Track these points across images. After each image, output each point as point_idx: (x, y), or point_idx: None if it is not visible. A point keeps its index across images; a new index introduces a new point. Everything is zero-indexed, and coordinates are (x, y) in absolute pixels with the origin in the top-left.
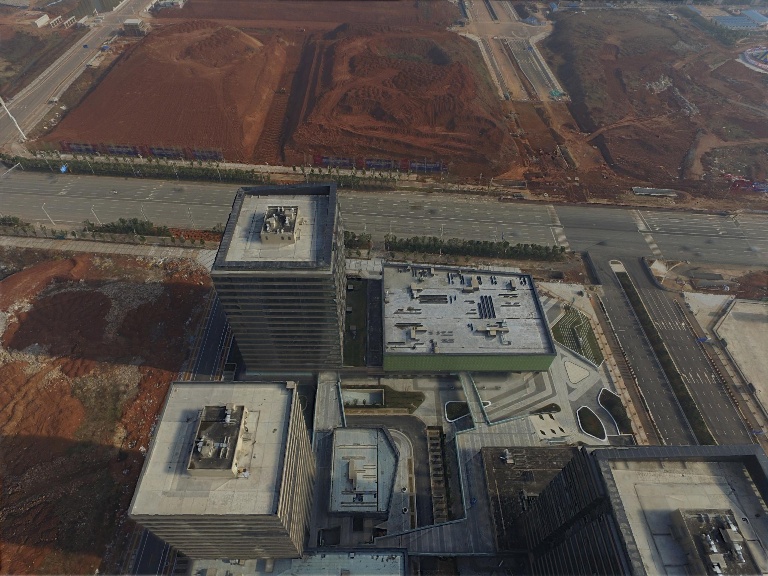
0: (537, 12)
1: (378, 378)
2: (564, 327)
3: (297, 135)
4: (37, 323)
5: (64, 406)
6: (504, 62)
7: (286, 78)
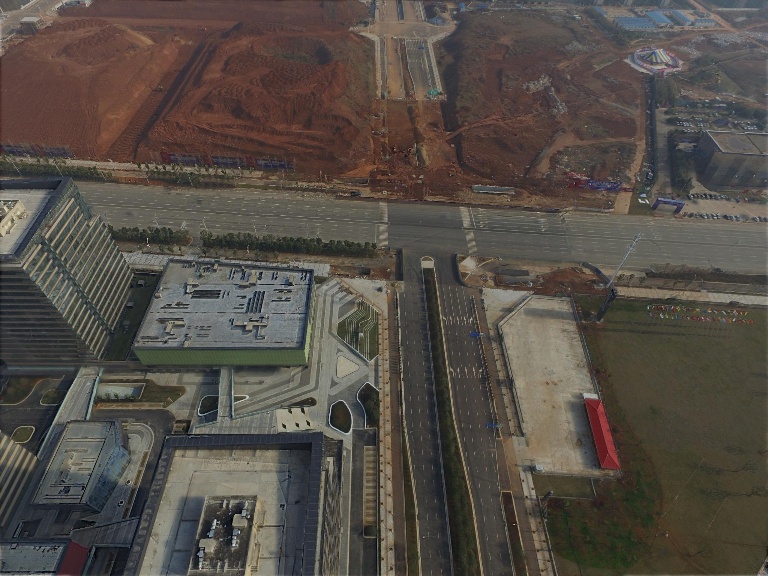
0: (445, 12)
1: (145, 373)
2: (350, 322)
3: (152, 133)
4: None
5: None
6: (393, 61)
7: (169, 76)
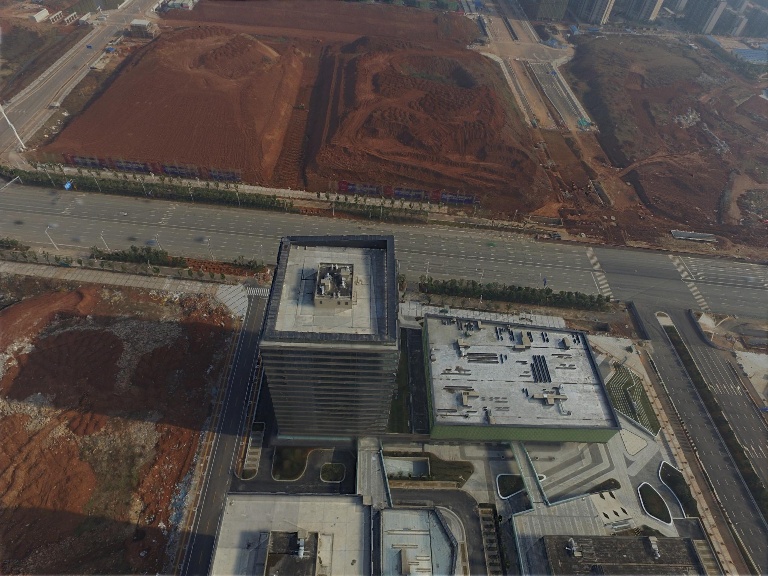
0: (557, 34)
1: (422, 444)
2: (616, 388)
3: (320, 158)
4: (40, 368)
5: (72, 472)
6: (528, 86)
7: (304, 92)
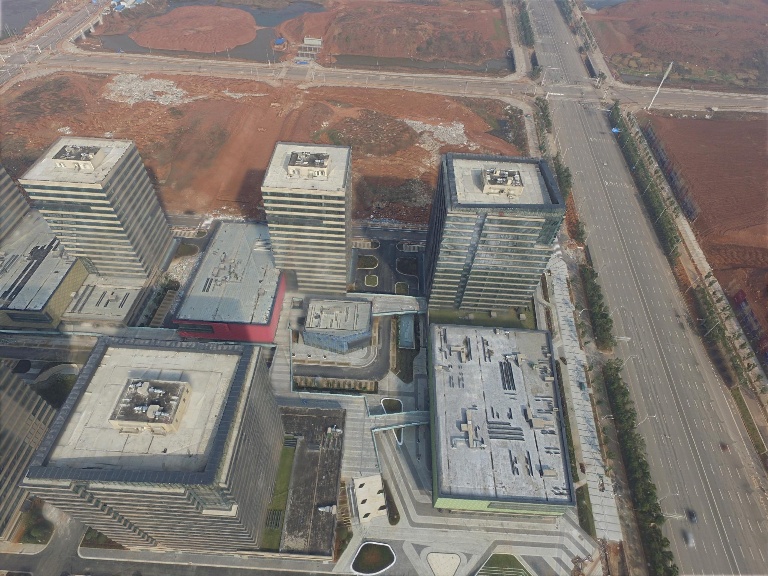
0: None
1: None
2: (517, 575)
3: None
4: None
5: (399, 177)
6: None
7: None
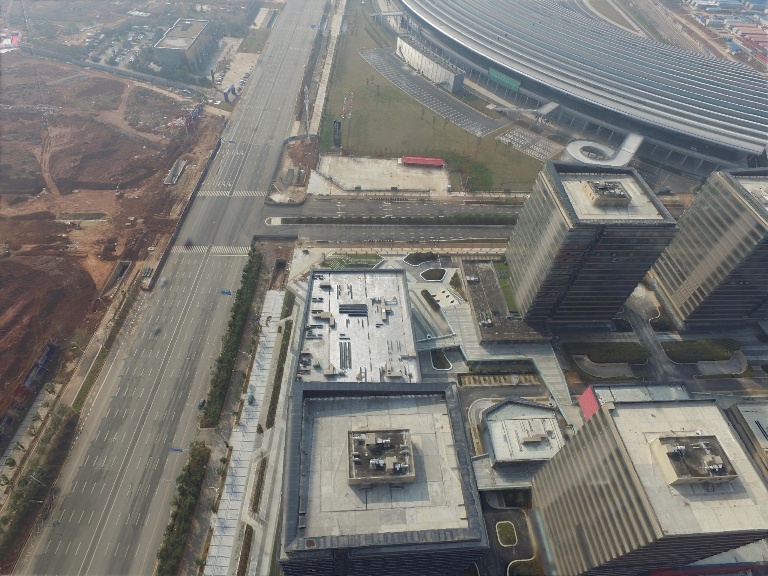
0: None
1: None
2: None
3: None
4: None
5: None
6: None
7: None
